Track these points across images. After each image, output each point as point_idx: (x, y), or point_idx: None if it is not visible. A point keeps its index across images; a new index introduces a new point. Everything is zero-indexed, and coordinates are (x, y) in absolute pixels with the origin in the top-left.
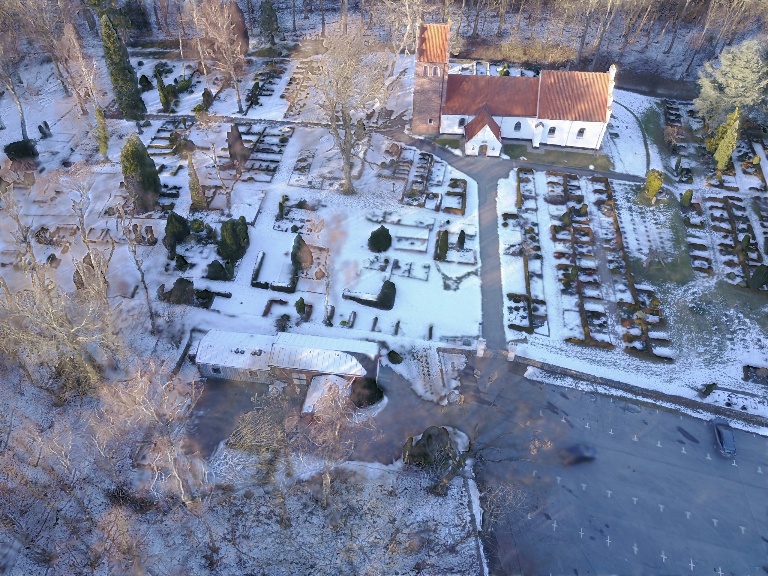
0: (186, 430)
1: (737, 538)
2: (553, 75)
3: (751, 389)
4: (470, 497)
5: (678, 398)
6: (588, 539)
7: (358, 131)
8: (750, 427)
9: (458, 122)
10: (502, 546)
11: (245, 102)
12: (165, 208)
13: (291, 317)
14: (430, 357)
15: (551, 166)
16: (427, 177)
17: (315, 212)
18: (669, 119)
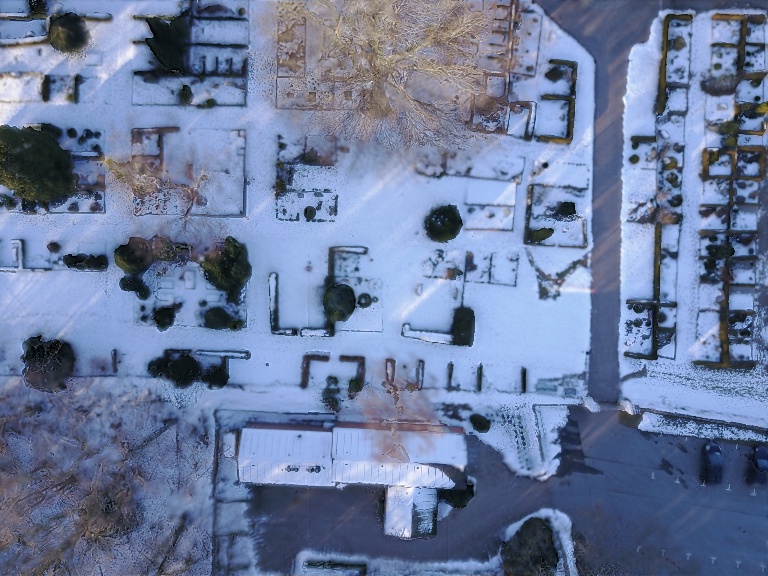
0: (254, 545)
1: None
2: None
3: None
4: None
5: None
6: None
7: None
8: None
9: None
10: None
11: None
12: (92, 190)
13: (339, 381)
14: (524, 417)
15: None
16: (510, 61)
17: (334, 168)
18: None
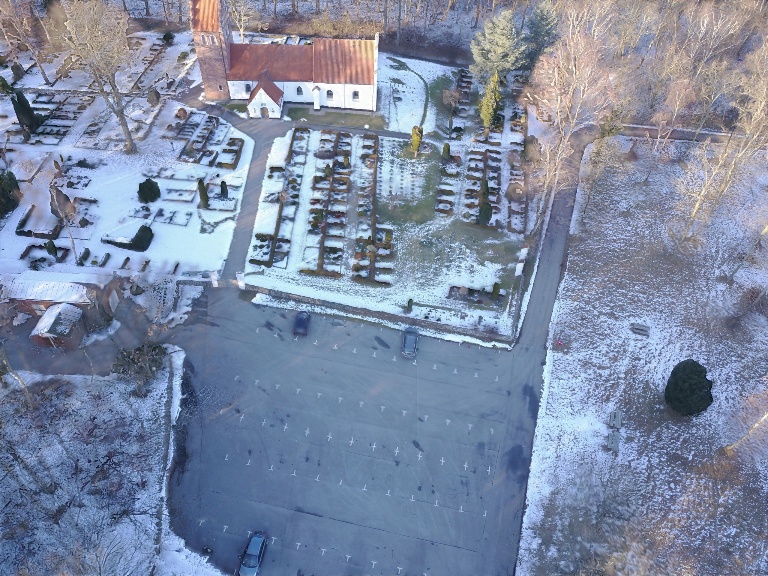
0: None
1: (397, 420)
2: (324, 43)
3: (450, 305)
4: (170, 398)
5: (382, 313)
6: (268, 427)
7: (150, 98)
8: (439, 334)
9: (245, 88)
10: (190, 436)
11: (55, 75)
12: None
13: (47, 259)
14: (169, 289)
15: (329, 126)
16: (208, 137)
17: (94, 170)
18: (460, 86)
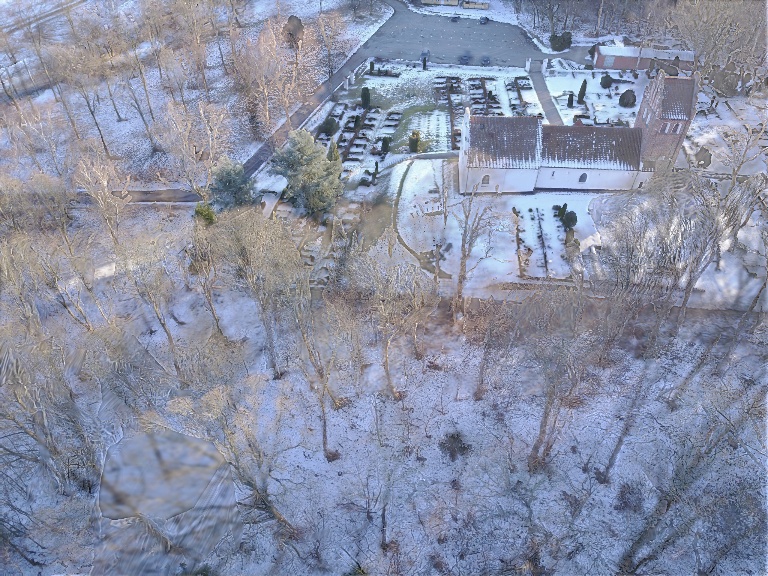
0: None
1: None
2: None
3: (400, 71)
4: None
5: None
6: (490, 39)
7: None
8: None
9: None
10: None
11: None
12: None
13: None
14: None
15: None
16: None
17: None
18: None
